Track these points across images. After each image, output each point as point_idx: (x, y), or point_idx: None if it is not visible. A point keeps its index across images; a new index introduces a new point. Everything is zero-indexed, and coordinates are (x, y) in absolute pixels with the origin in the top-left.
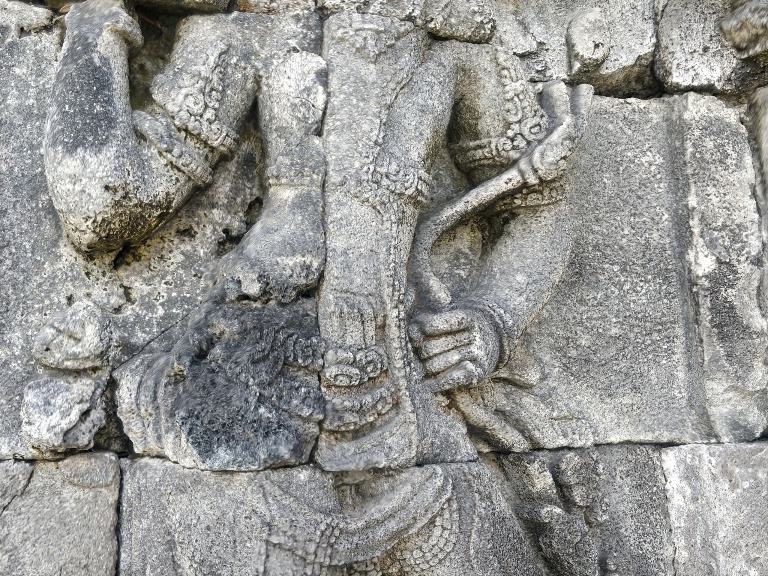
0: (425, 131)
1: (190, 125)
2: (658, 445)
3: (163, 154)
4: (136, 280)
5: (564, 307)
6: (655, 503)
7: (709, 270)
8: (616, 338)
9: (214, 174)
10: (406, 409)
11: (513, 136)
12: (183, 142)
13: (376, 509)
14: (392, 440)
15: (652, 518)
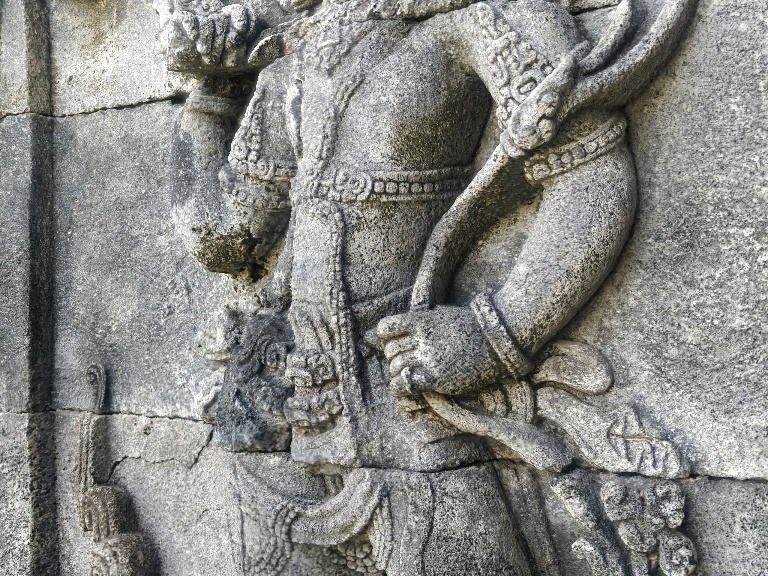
0: (383, 130)
1: (238, 169)
2: None
3: None
4: None
5: (663, 292)
6: None
7: None
8: (742, 332)
9: None
10: None
11: (505, 102)
12: (244, 182)
13: None
14: (337, 440)
15: None
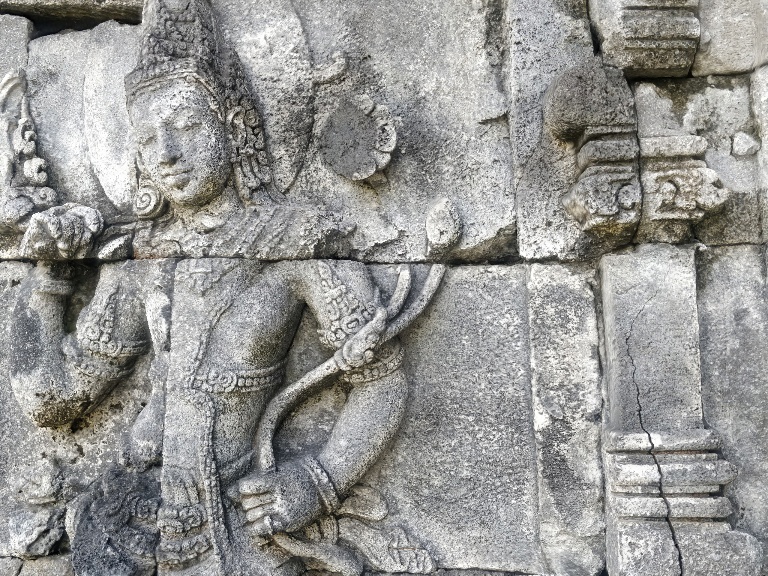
0: (246, 341)
1: (90, 348)
2: (510, 573)
3: (76, 367)
4: (85, 441)
5: (419, 453)
6: None
7: (543, 426)
8: (467, 480)
9: (135, 365)
10: (213, 552)
11: (335, 331)
12: (91, 357)
13: None
14: (206, 573)
15: None
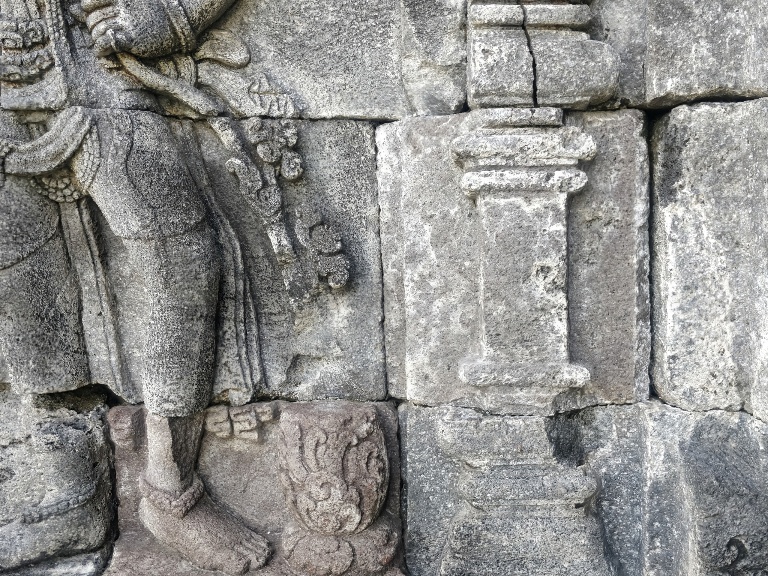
0: None
1: None
2: (376, 122)
3: None
4: None
5: None
6: (362, 170)
7: None
8: (332, 25)
9: None
10: None
11: None
12: None
13: None
14: (49, 88)
15: (358, 182)
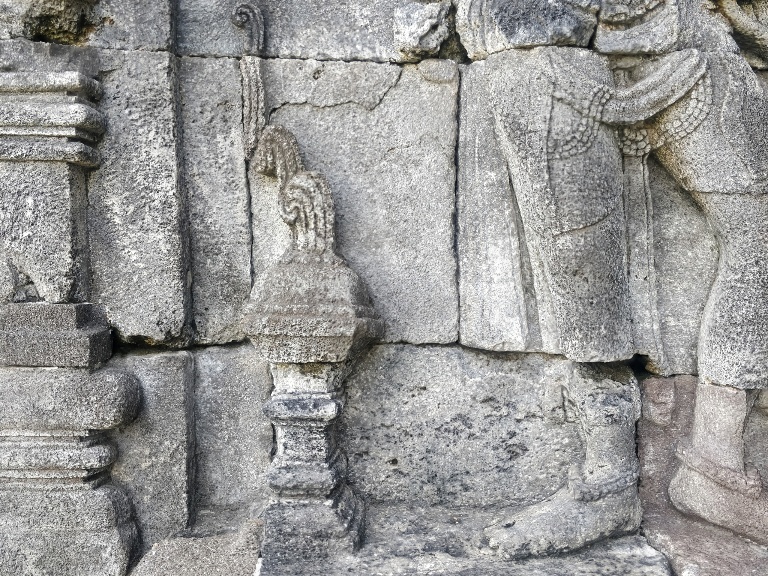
0: None
1: None
2: None
3: None
4: None
5: None
6: None
7: None
8: None
9: None
10: (669, 3)
11: None
12: None
13: (641, 83)
14: (657, 29)
15: None
